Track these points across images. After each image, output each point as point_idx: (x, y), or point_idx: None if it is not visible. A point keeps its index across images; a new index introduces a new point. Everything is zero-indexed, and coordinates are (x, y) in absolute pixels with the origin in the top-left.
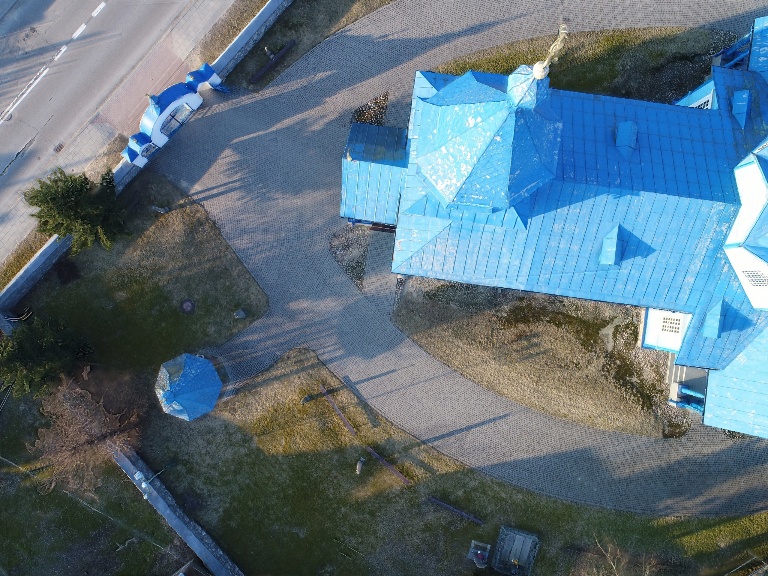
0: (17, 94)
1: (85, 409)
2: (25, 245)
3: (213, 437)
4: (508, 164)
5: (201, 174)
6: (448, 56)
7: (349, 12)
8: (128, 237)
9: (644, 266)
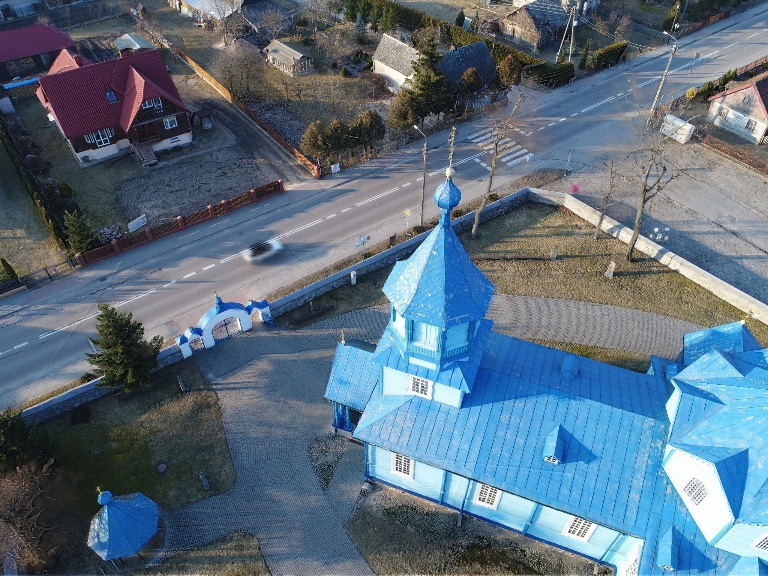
0: (126, 299)
1: (26, 488)
2: (63, 389)
3: None
4: (443, 281)
5: (227, 372)
6: None
7: (379, 299)
8: (148, 386)
9: (587, 473)
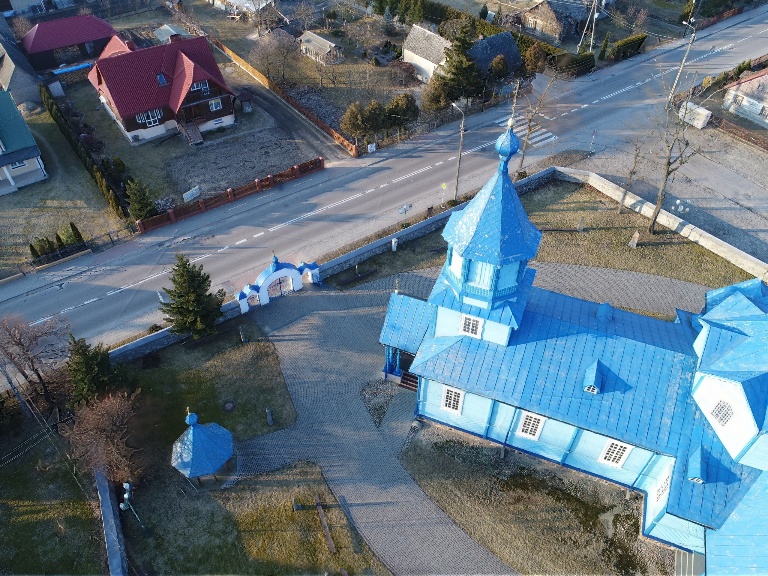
0: None
1: None
2: (133, 339)
3: (196, 520)
4: (499, 223)
5: (282, 326)
6: None
7: (418, 264)
8: (215, 333)
9: (623, 401)
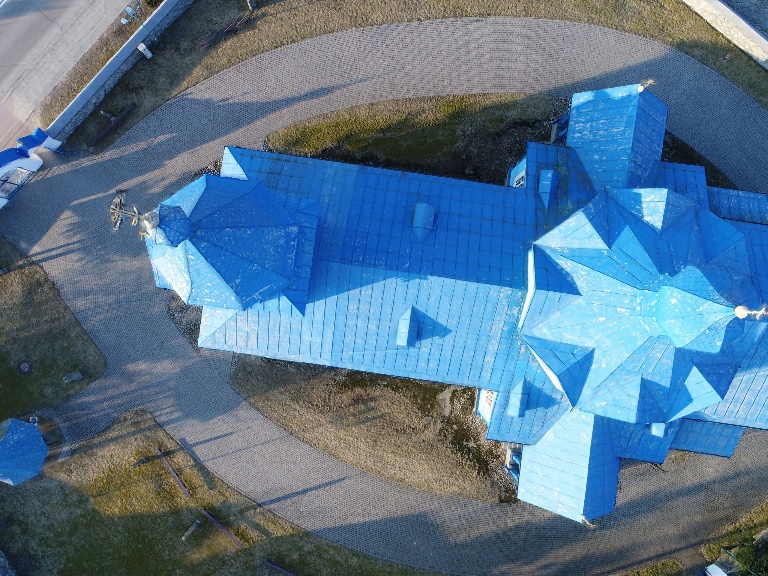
0: None
1: None
2: None
3: (49, 498)
4: (218, 276)
5: (40, 235)
6: (288, 120)
7: (190, 75)
8: None
9: (443, 345)
